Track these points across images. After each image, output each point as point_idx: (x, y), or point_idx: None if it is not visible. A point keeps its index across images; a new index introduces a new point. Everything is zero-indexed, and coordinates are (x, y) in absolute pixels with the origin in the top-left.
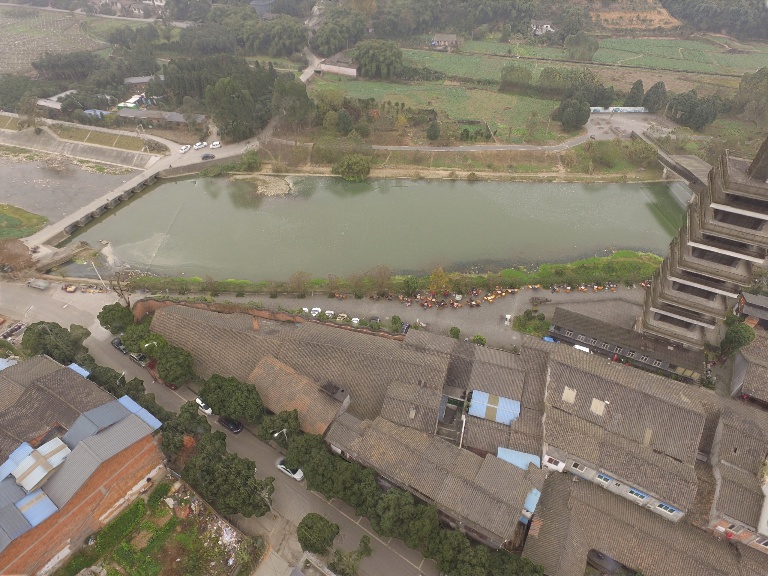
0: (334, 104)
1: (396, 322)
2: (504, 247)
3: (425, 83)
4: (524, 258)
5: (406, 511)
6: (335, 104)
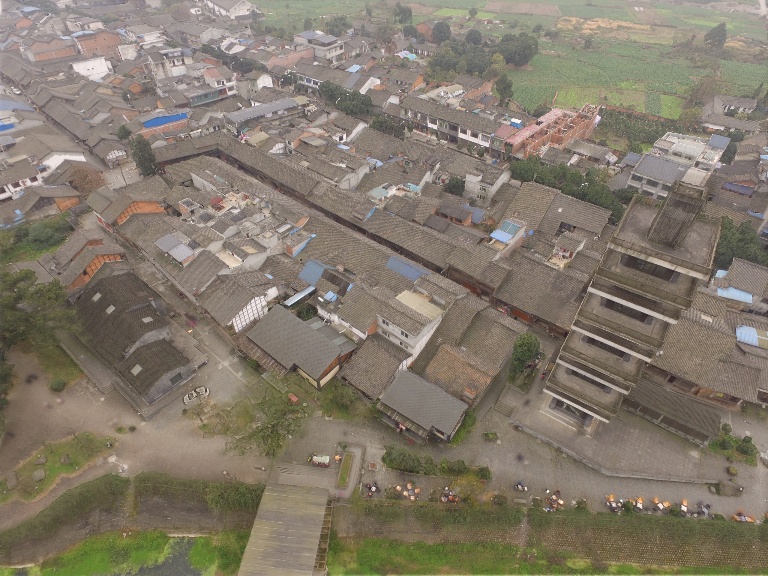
0: None
1: None
2: None
3: None
4: None
5: None
6: None
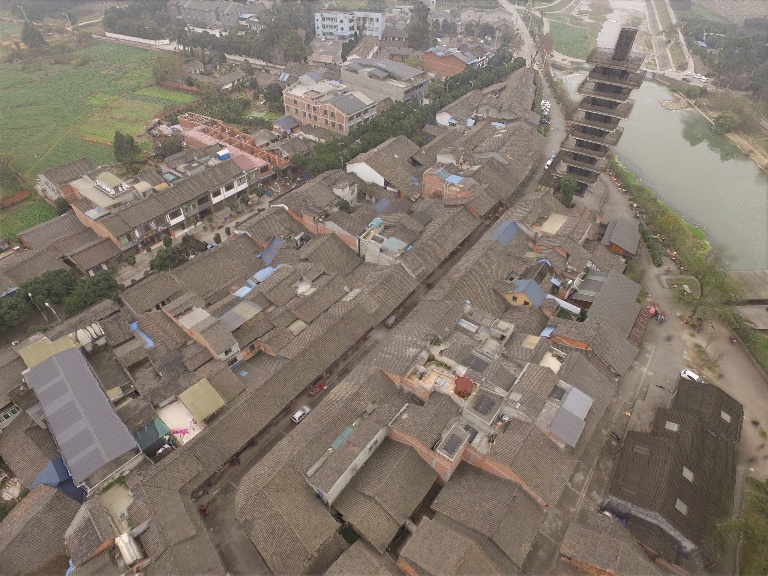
0: None
1: (546, 116)
2: (663, 177)
3: None
4: (654, 183)
5: None
6: None
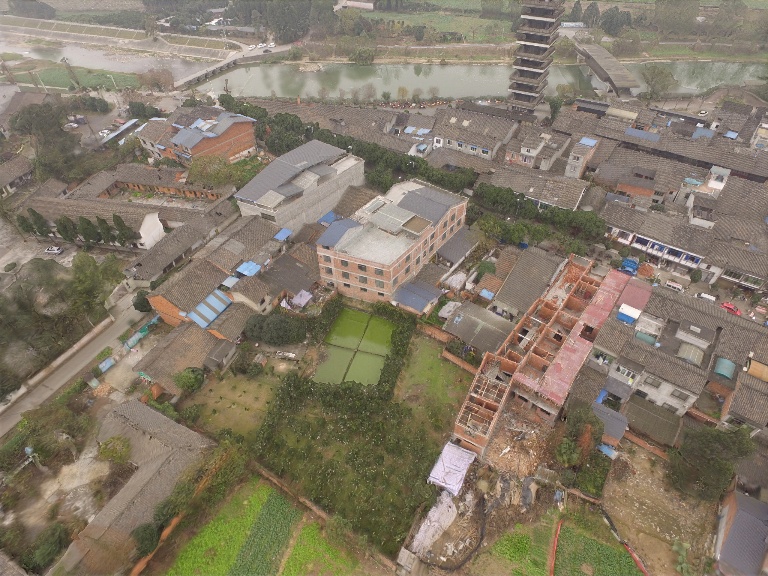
0: (352, 18)
1: None
2: (452, 93)
3: (424, 13)
4: None
5: (364, 145)
6: (353, 18)
